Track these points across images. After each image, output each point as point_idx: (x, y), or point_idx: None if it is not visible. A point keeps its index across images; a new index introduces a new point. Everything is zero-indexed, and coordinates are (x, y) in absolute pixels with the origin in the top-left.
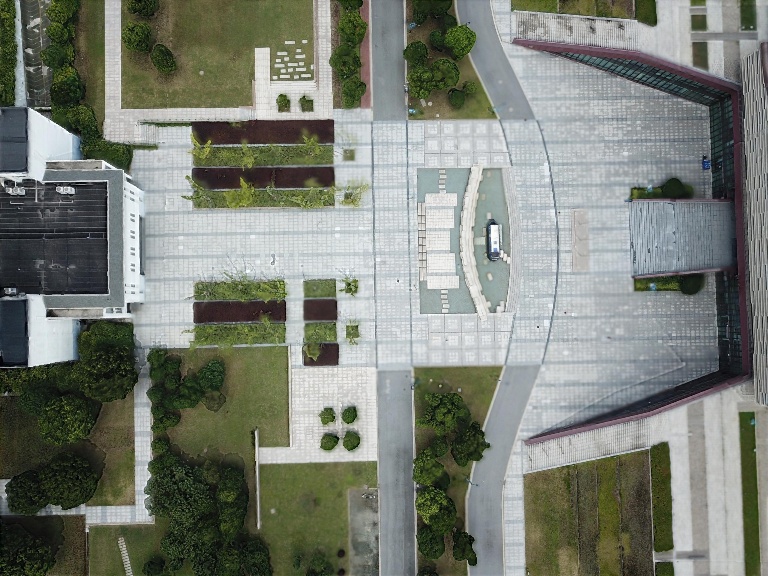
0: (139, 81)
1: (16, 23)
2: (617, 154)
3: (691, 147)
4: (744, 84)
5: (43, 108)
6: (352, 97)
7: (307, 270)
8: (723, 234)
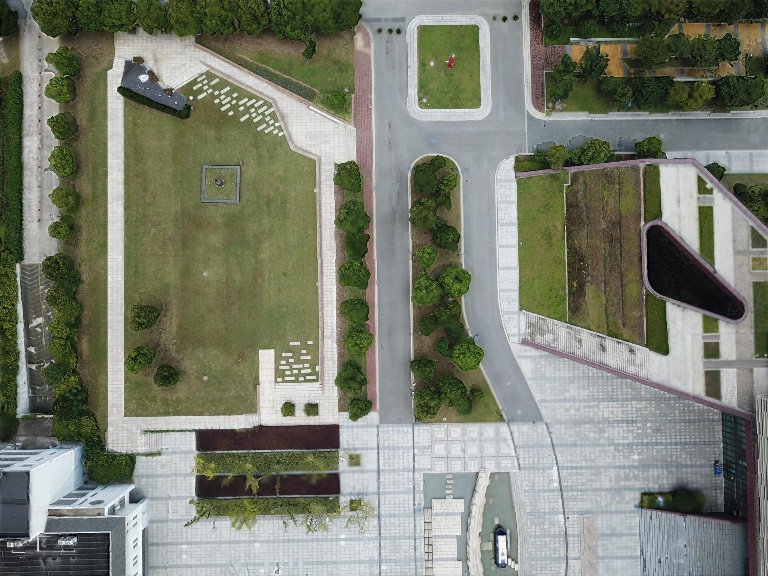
0: (142, 388)
1: (18, 327)
2: (627, 457)
3: (703, 450)
4: (758, 424)
5: (45, 416)
6: (358, 416)
7: None
8: (735, 554)
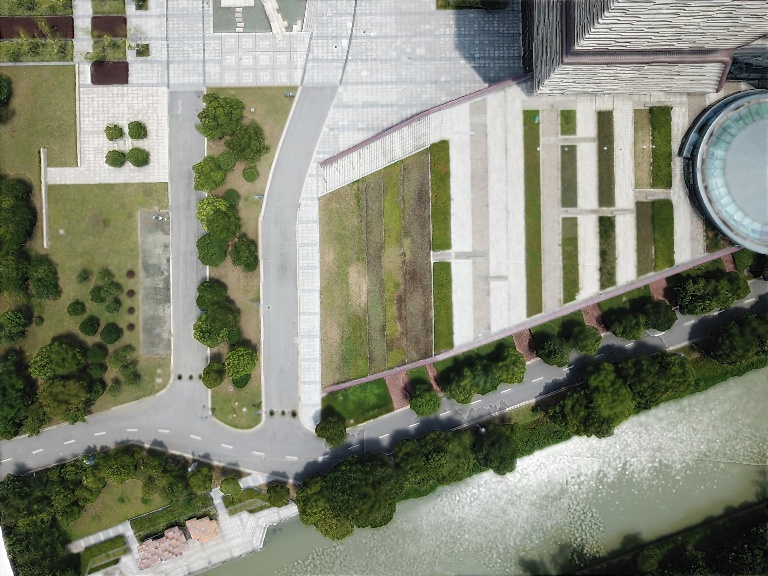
0: None
1: None
2: None
3: None
4: None
5: None
6: None
7: None
8: None
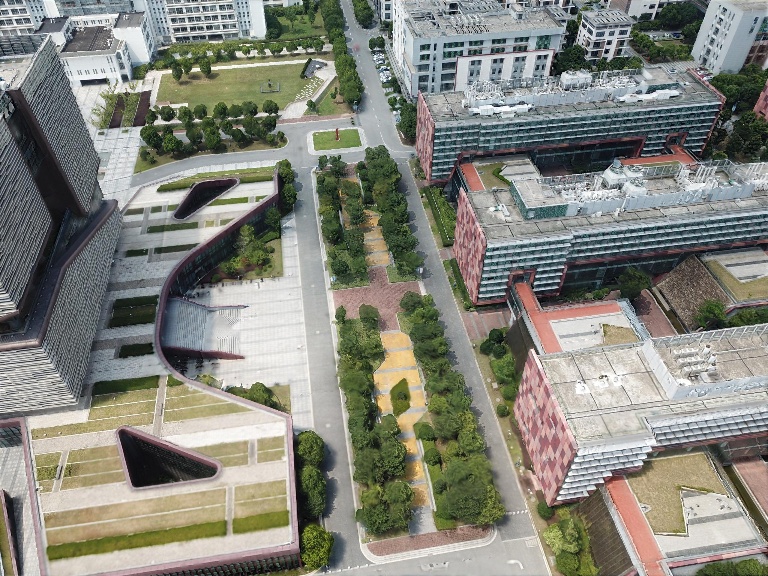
0: None
1: (207, 52)
2: None
3: None
4: None
5: None
6: None
7: None
8: None
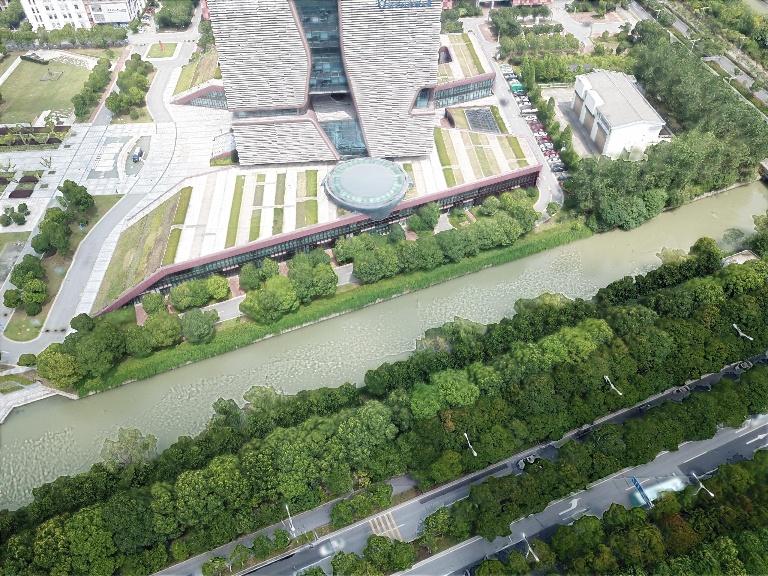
0: None
1: None
2: None
3: None
4: None
5: None
6: (78, 110)
7: (31, 168)
8: None
